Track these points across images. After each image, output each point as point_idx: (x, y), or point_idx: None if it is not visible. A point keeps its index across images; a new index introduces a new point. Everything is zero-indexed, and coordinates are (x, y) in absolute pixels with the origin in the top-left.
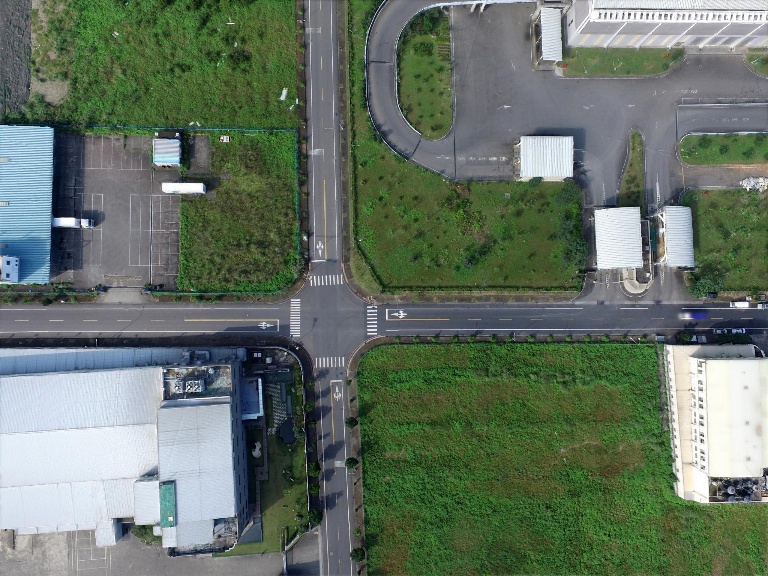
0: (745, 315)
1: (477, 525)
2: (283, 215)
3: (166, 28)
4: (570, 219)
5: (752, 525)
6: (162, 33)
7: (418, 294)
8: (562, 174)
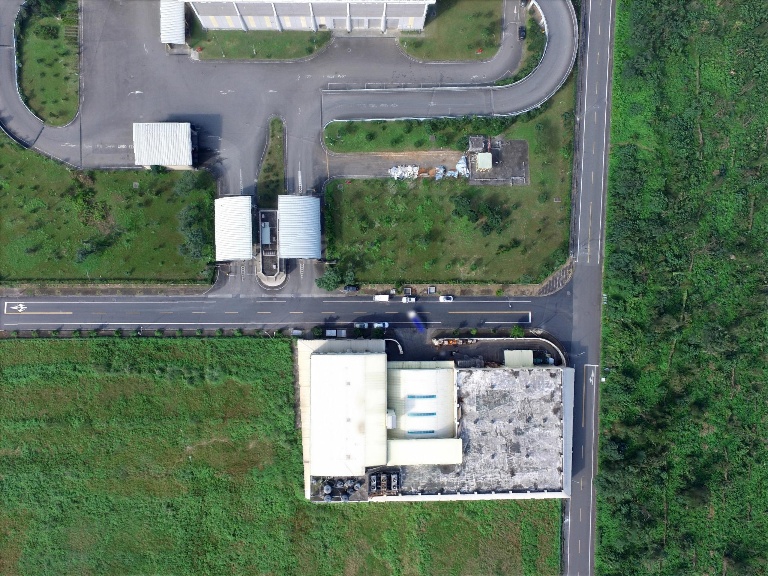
0: (390, 309)
1: (94, 524)
2: None
3: None
4: (203, 209)
5: (390, 525)
6: None
7: (39, 287)
8: (180, 162)
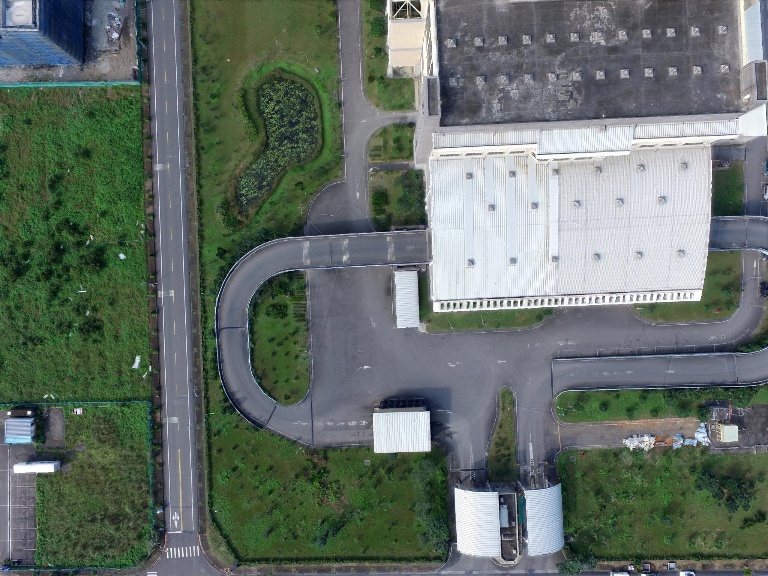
0: None
1: None
2: (137, 489)
3: (18, 300)
4: (435, 485)
5: None
6: (14, 306)
7: (276, 566)
8: (419, 449)
